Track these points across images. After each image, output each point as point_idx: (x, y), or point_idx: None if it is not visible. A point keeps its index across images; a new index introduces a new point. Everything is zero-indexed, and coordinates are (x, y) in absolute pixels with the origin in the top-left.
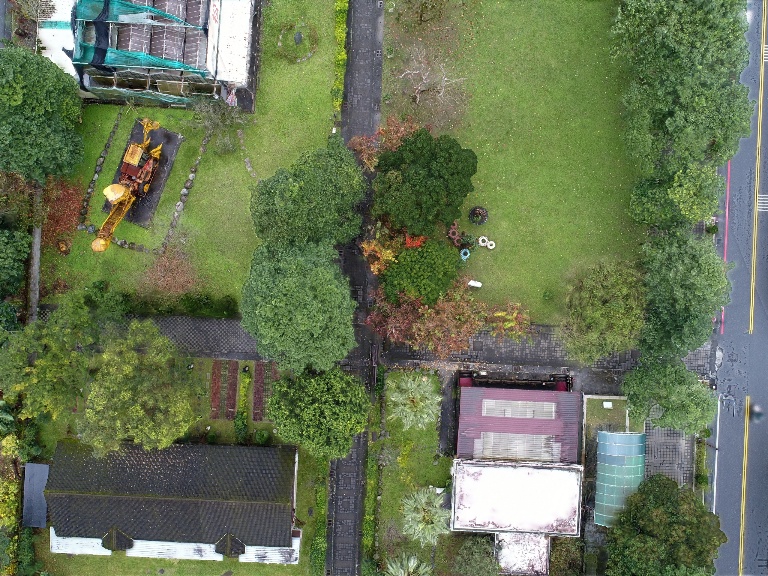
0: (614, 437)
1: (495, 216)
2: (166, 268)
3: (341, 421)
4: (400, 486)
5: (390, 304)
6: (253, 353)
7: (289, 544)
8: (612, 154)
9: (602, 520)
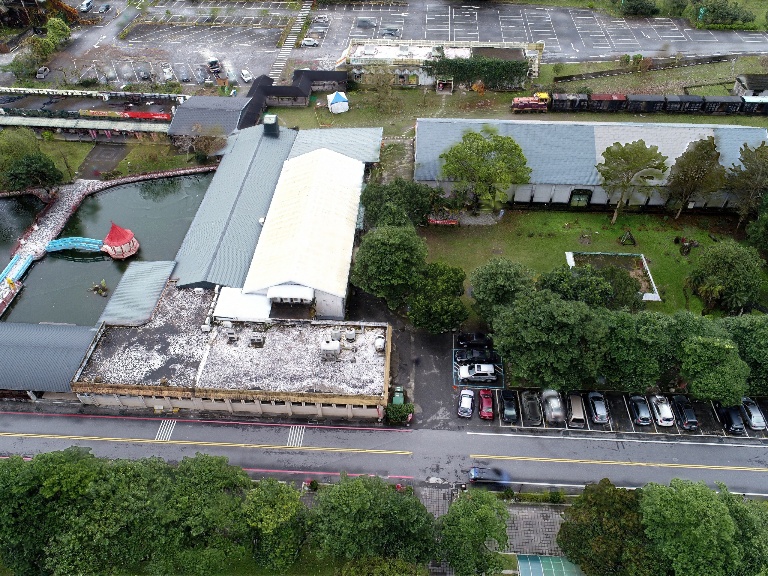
0: None
1: None
2: None
3: None
4: None
5: None
6: None
7: None
8: None
9: None
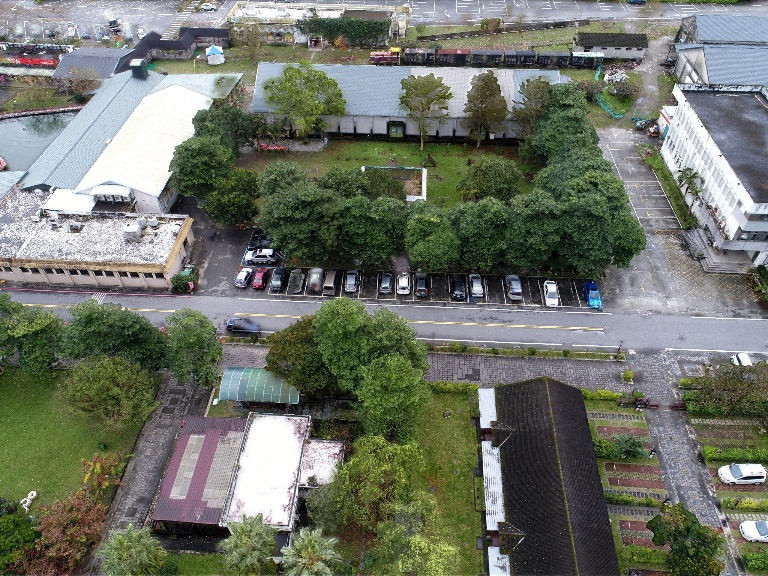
0: (223, 387)
1: (7, 492)
2: None
3: None
4: None
5: None
6: None
7: None
8: (4, 397)
9: (294, 397)
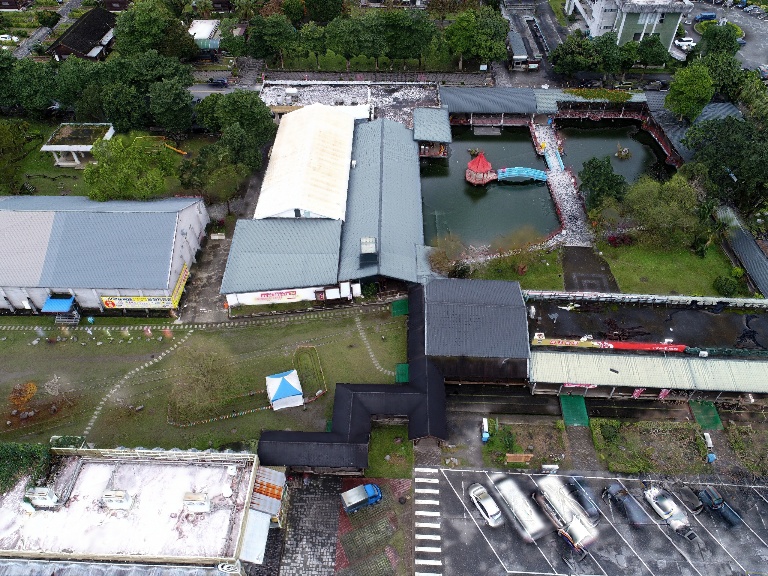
0: None
1: None
2: None
3: None
4: None
5: None
6: None
7: None
8: None
9: None
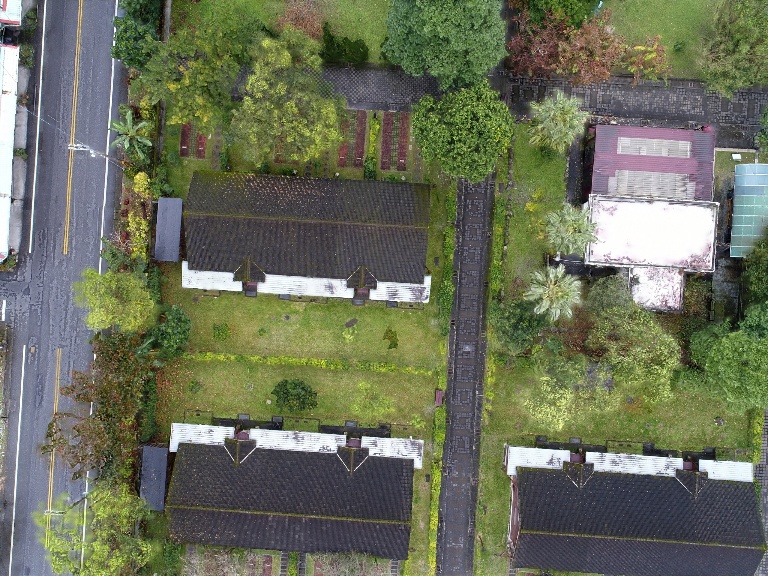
0: (753, 167)
1: None
2: (297, 16)
3: (494, 122)
4: (527, 236)
5: (535, 25)
6: (382, 103)
7: (421, 280)
8: None
9: (739, 251)
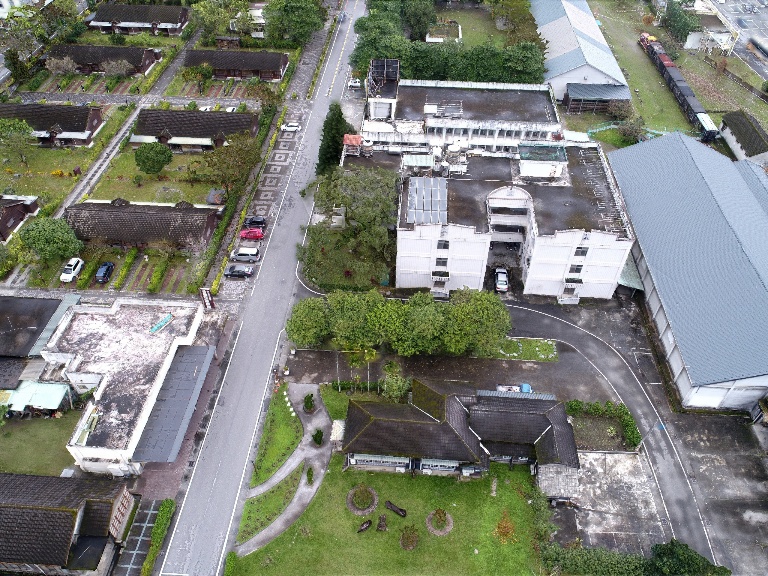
0: None
1: None
2: None
3: None
4: None
5: None
6: None
7: (177, 22)
8: None
9: None
